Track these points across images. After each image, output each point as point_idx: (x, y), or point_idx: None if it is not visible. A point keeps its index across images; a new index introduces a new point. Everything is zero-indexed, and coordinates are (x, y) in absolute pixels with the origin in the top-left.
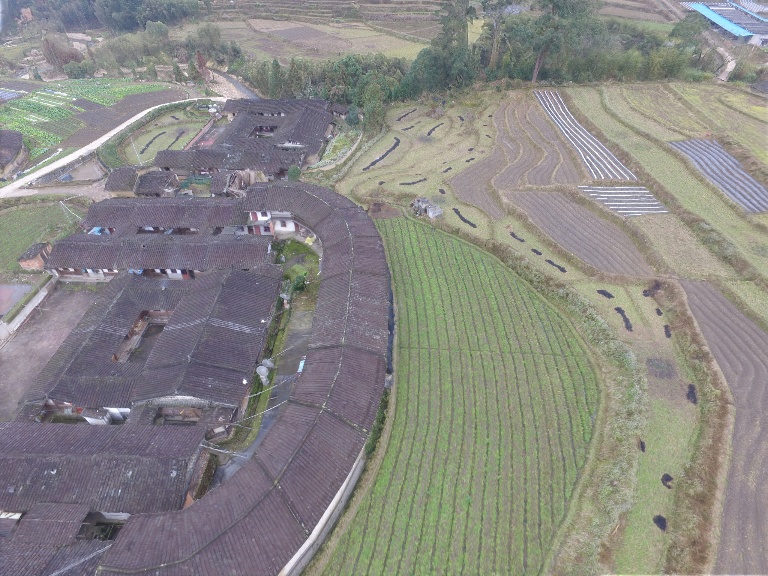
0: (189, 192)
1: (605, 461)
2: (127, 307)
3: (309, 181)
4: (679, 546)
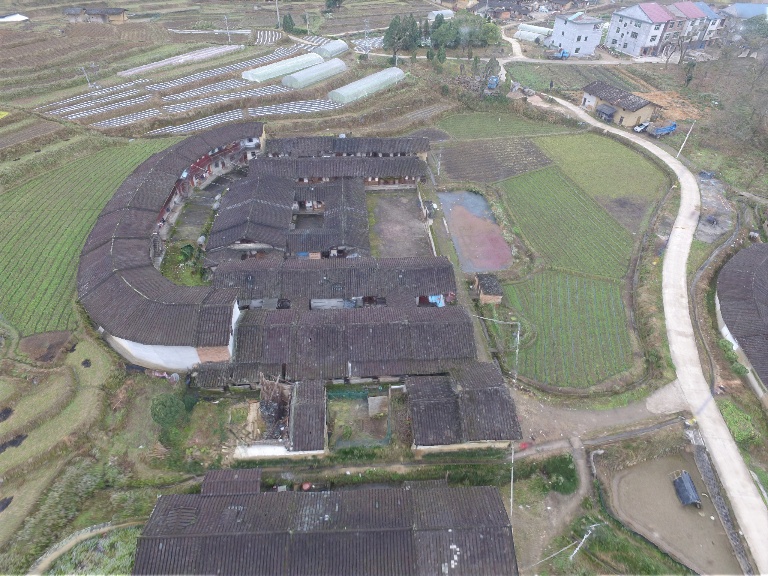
0: (369, 402)
1: (37, 171)
2: (333, 224)
3: (146, 450)
4: (40, 142)
